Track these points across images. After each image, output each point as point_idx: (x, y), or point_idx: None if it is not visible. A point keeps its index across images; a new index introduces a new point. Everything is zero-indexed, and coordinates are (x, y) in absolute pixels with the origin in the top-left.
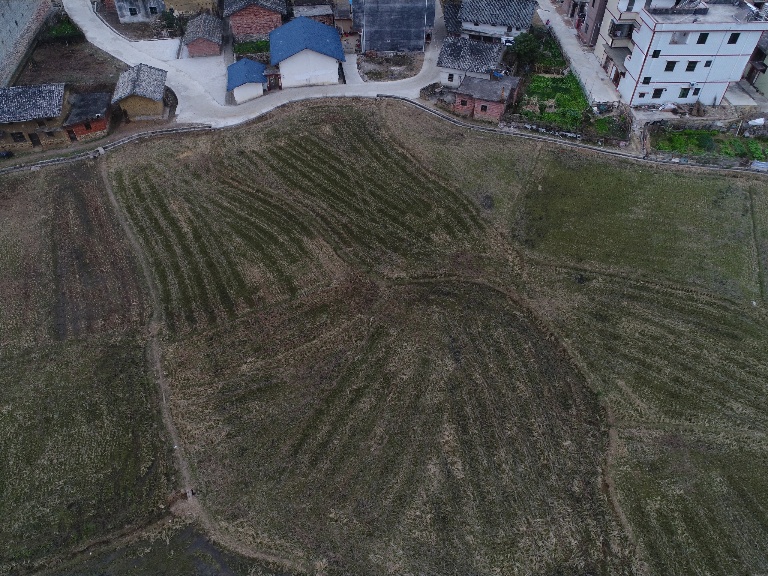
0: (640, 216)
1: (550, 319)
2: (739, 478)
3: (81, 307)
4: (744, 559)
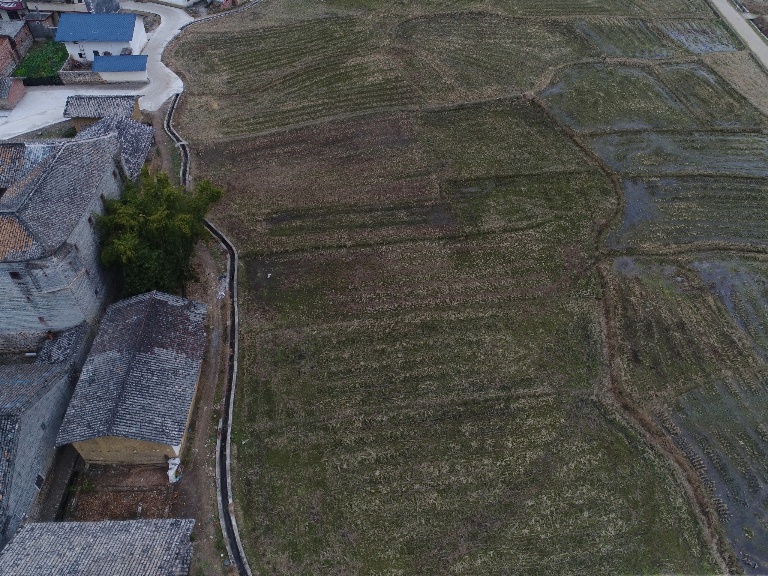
0: None
1: (428, 13)
2: None
3: None
4: (540, 4)
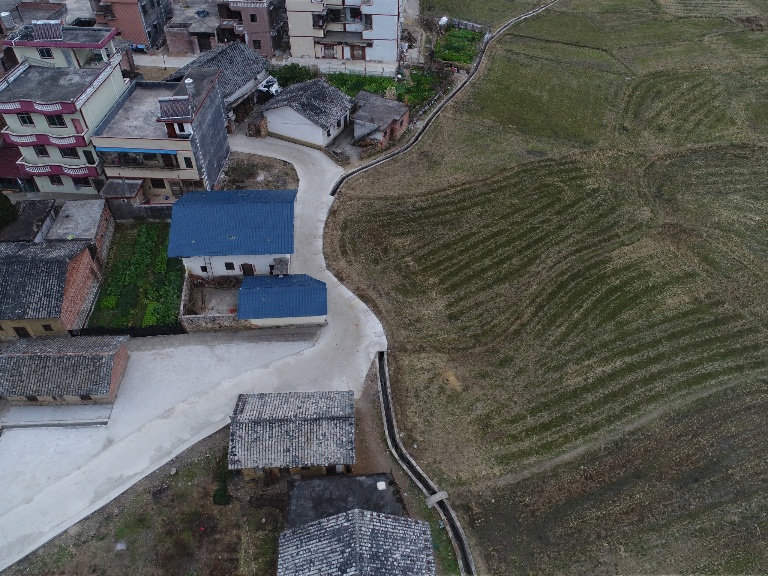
0: (545, 94)
1: (672, 148)
2: (766, 116)
3: None
4: None
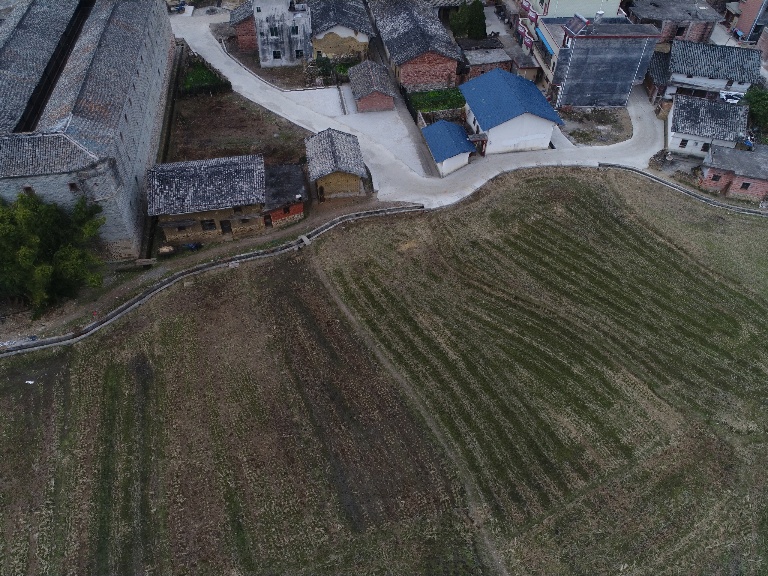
0: None
1: None
2: None
3: (367, 478)
4: None
